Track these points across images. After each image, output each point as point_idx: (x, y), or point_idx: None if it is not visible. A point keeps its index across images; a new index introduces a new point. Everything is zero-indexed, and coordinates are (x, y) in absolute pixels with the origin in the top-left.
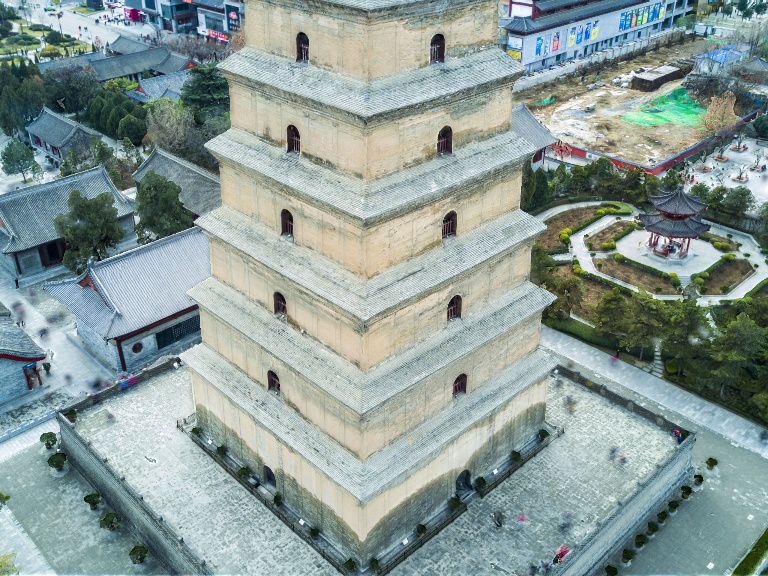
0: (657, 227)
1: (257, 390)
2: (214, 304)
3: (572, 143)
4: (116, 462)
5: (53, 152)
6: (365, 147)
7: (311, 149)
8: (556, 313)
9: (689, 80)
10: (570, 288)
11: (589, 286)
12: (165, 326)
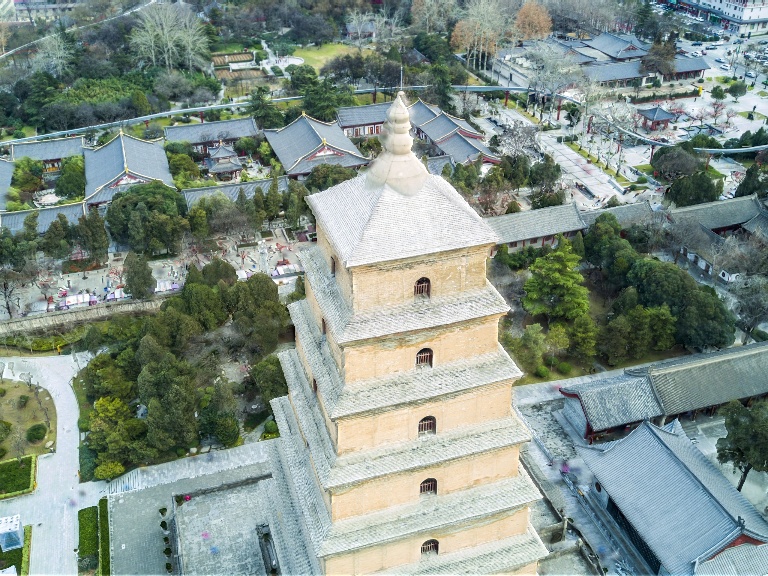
0: None
1: None
2: None
3: None
4: None
5: None
6: None
7: None
8: None
9: None
10: None
11: None
12: None
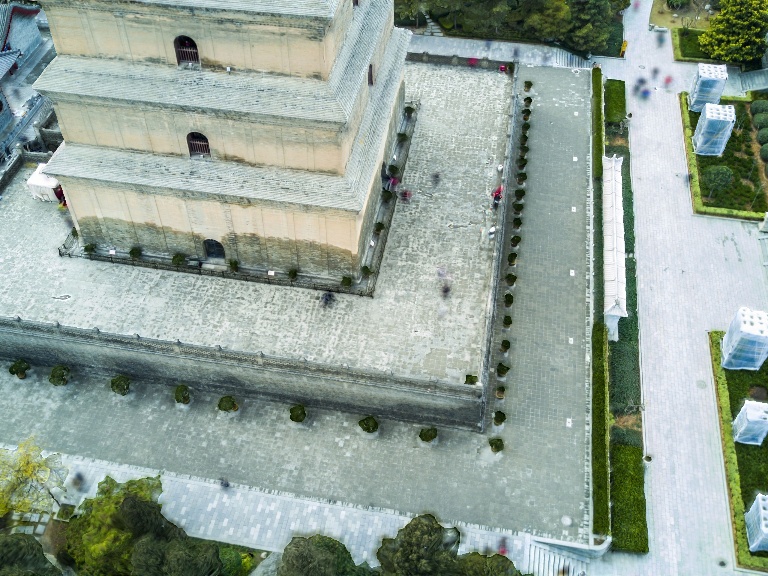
0: None
1: (175, 163)
2: (84, 86)
3: None
4: (25, 318)
5: None
6: None
7: None
8: None
9: None
10: None
11: None
12: None
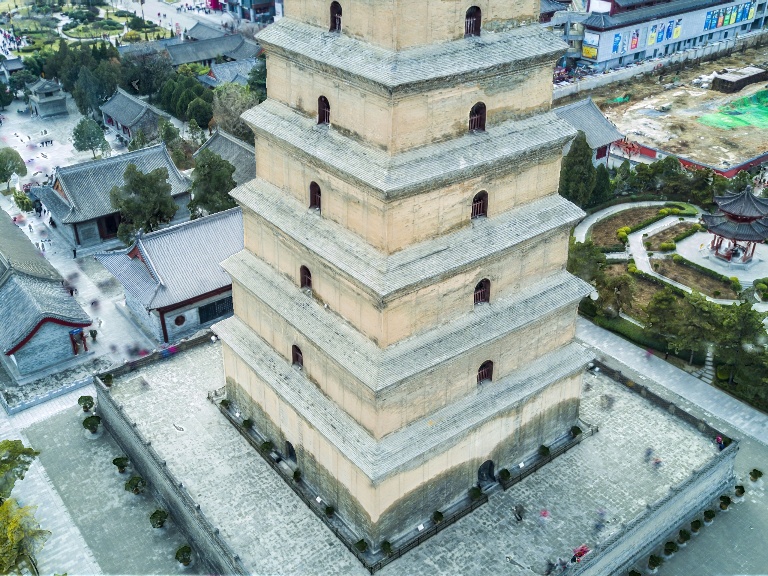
0: (720, 229)
1: (282, 364)
2: (244, 276)
3: (643, 142)
4: (145, 428)
5: (124, 131)
6: (390, 118)
7: (340, 120)
8: (604, 311)
9: None
10: (621, 286)
11: (643, 286)
12: (208, 301)
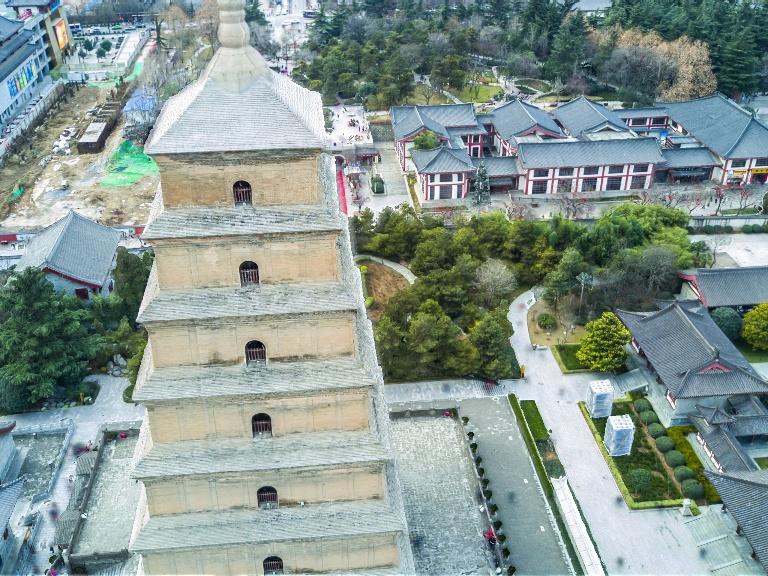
0: None
1: None
2: (178, 540)
3: None
4: None
5: None
6: (352, 331)
7: (282, 353)
8: None
9: (128, 132)
10: None
11: None
12: None
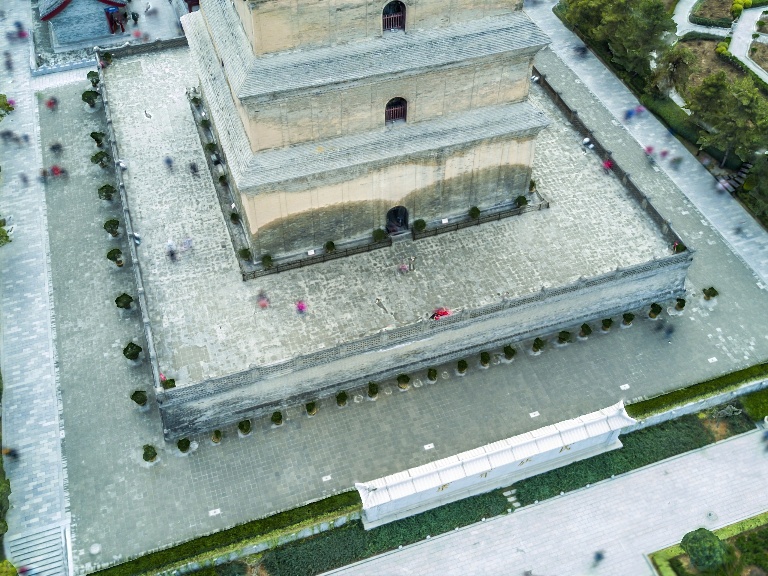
0: None
1: (216, 64)
2: None
3: None
4: (120, 108)
5: None
6: None
7: None
8: (653, 89)
9: None
10: (680, 62)
11: None
12: None
